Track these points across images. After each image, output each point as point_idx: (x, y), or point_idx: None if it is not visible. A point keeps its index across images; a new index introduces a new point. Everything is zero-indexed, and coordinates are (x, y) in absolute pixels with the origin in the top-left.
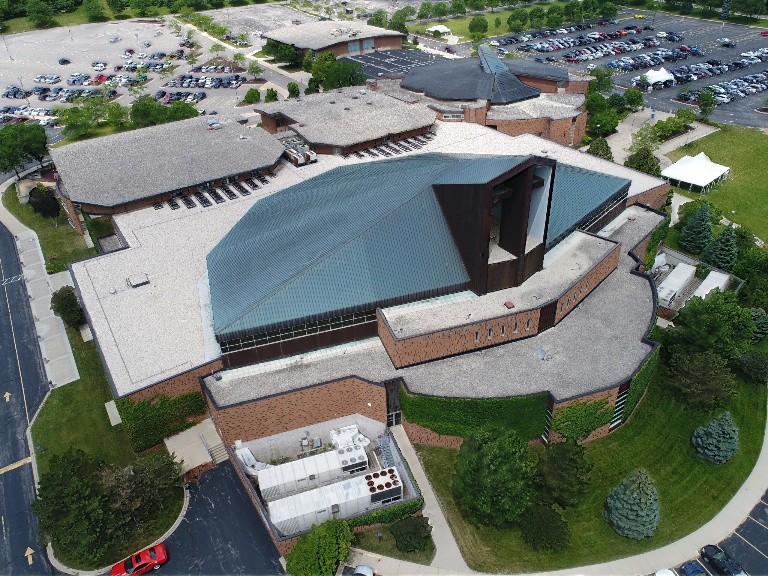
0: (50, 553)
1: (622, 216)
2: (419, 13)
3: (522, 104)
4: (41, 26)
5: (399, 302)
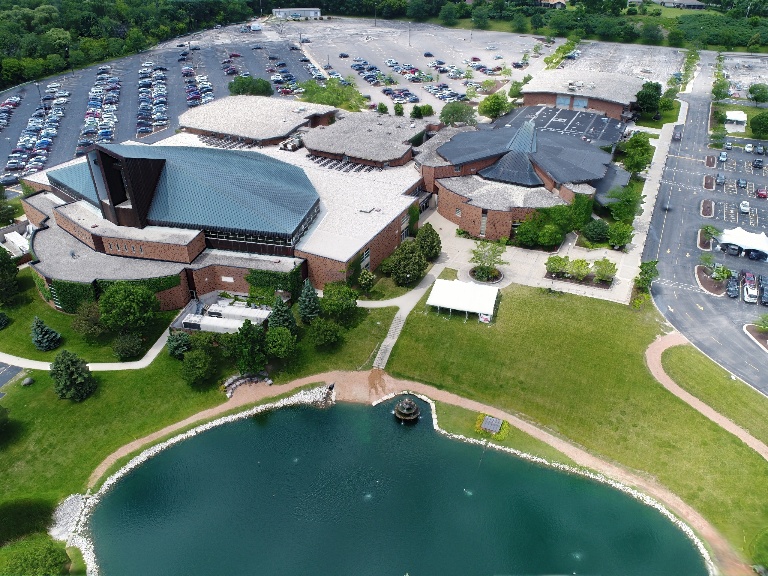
0: None
1: (280, 258)
2: None
3: (497, 185)
4: (459, 27)
5: (88, 201)
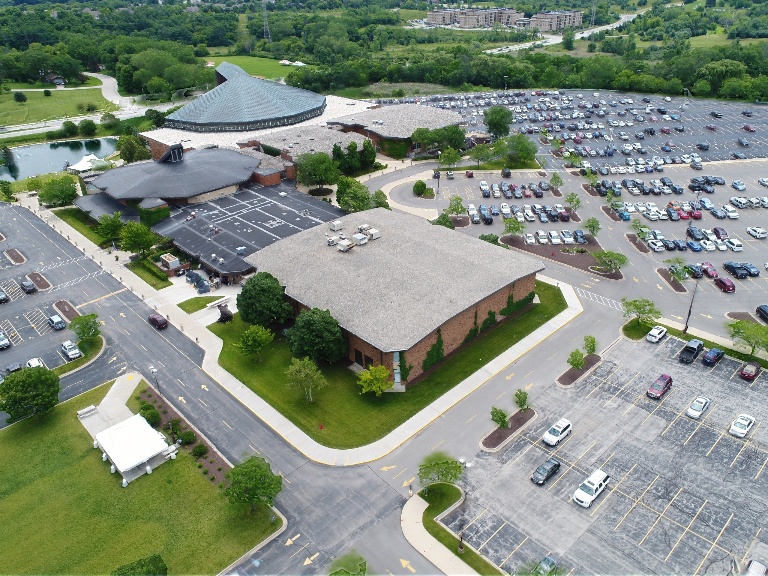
0: None
1: None
2: (155, 569)
3: None
4: None
5: None
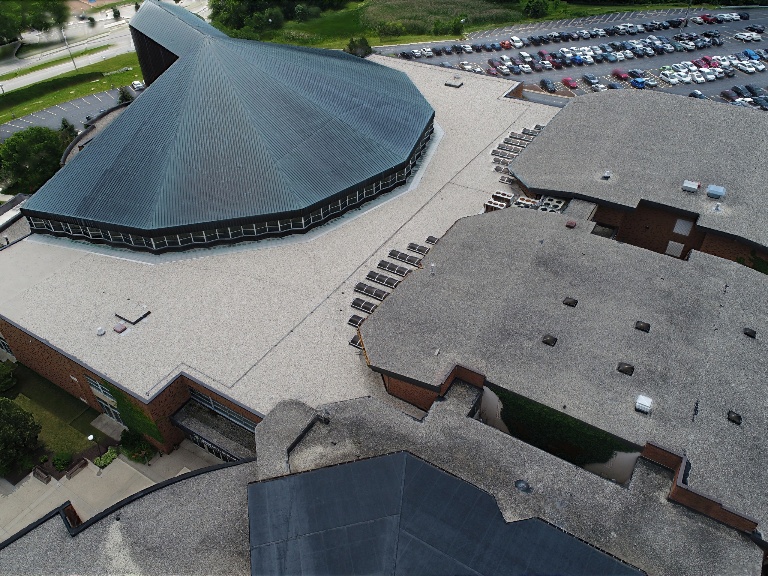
0: None
1: None
2: None
3: None
4: None
5: None
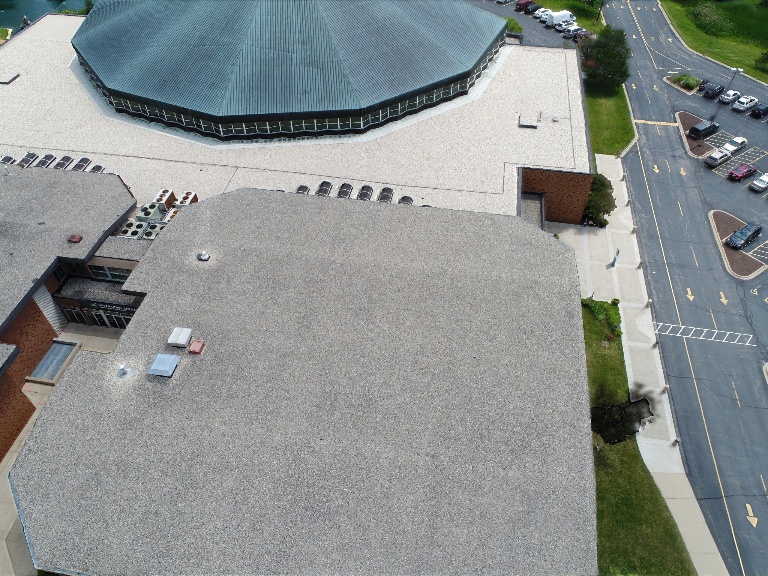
0: (623, 83)
1: None
2: None
3: None
4: None
5: None
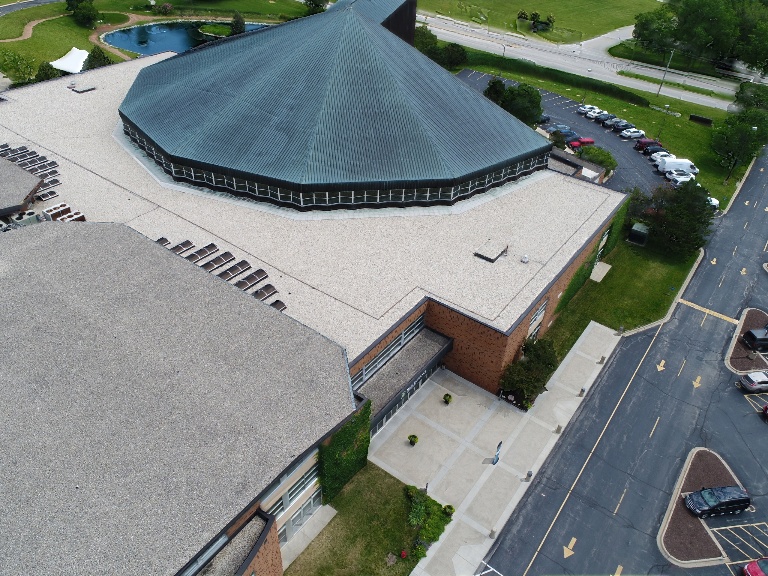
0: (702, 254)
1: None
2: None
3: None
4: None
5: None
